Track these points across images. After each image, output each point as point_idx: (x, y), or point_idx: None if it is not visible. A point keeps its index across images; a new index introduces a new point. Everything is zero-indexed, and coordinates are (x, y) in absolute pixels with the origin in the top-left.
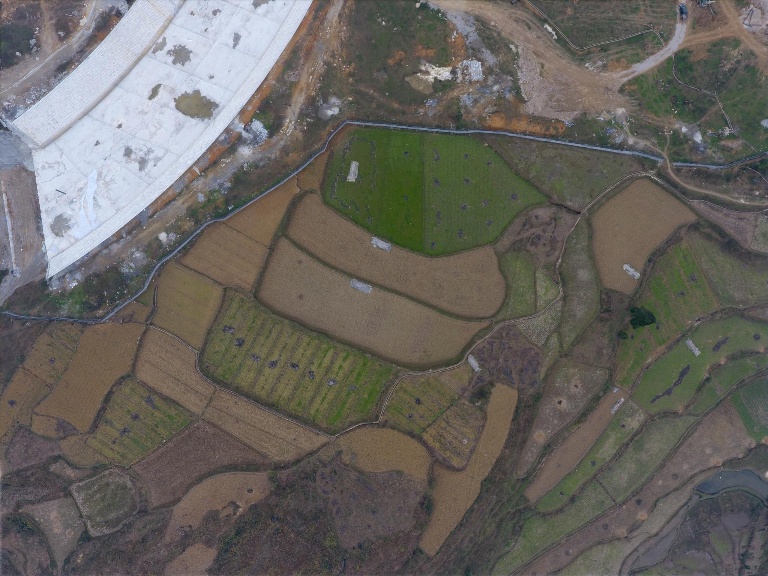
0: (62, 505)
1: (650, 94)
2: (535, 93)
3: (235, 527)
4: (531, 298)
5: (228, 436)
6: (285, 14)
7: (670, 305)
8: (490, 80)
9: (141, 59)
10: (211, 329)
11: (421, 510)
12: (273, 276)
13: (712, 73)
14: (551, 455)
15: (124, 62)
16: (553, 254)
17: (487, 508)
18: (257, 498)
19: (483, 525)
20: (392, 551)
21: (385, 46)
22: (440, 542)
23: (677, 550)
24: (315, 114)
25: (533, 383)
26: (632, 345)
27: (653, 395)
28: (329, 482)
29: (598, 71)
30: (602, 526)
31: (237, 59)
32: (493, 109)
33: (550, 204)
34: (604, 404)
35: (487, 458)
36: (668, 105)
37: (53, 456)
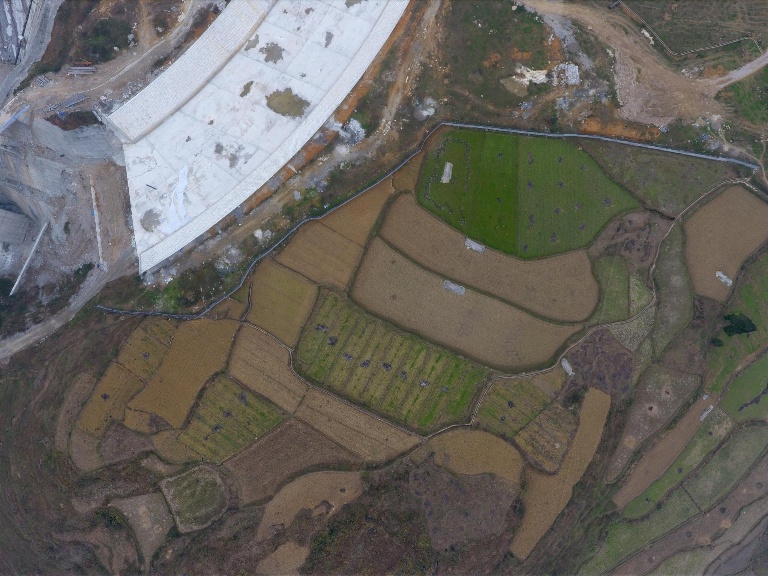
0: (151, 500)
1: (747, 101)
2: (631, 98)
3: (329, 526)
4: (624, 303)
5: (320, 435)
6: (378, 14)
7: (761, 313)
8: (586, 84)
9: (233, 56)
10: (304, 327)
11: (513, 513)
12: (366, 276)
13: None
14: (640, 461)
15: (218, 59)
16: (647, 259)
17: (577, 513)
18: (350, 498)
19: (572, 530)
20: (484, 554)
21: (481, 48)
22: (531, 546)
23: (758, 559)
24: (411, 114)
25: (625, 388)
26: (722, 352)
27: (741, 403)
28: (422, 483)
29: (694, 77)
30: (686, 533)
31: (329, 58)
32: (588, 113)
33: (644, 209)
34: (693, 411)
35: (579, 463)
36: (765, 113)
37: (145, 451)
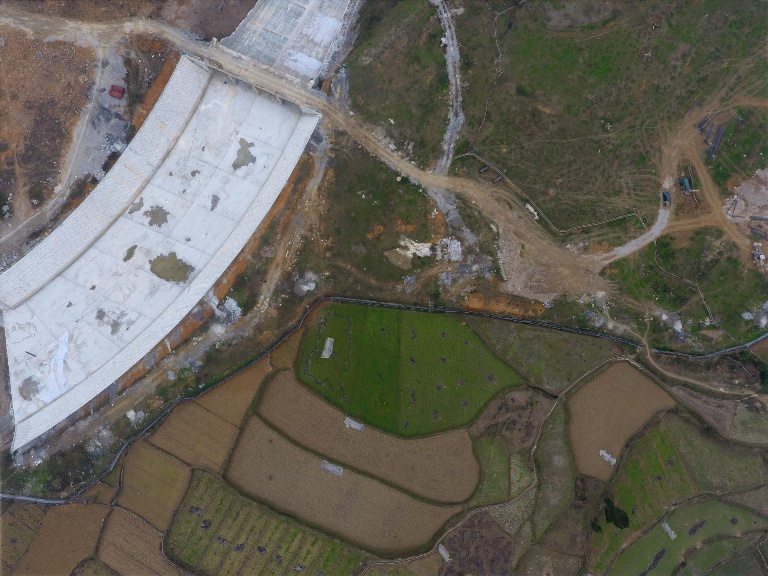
0: None
1: (631, 279)
2: (515, 274)
3: None
4: (505, 484)
5: None
6: (265, 177)
7: (646, 489)
8: (469, 260)
9: (117, 219)
10: (177, 510)
11: None
12: (243, 455)
13: (694, 263)
14: None
15: (99, 224)
16: (528, 440)
17: None
18: None
19: None
20: None
21: (364, 220)
22: None
23: None
24: (291, 289)
25: (504, 573)
26: (607, 530)
27: None
28: None
29: (579, 253)
30: None
31: (215, 222)
32: (472, 288)
33: (527, 387)
34: None
35: None
36: (649, 291)
37: None
